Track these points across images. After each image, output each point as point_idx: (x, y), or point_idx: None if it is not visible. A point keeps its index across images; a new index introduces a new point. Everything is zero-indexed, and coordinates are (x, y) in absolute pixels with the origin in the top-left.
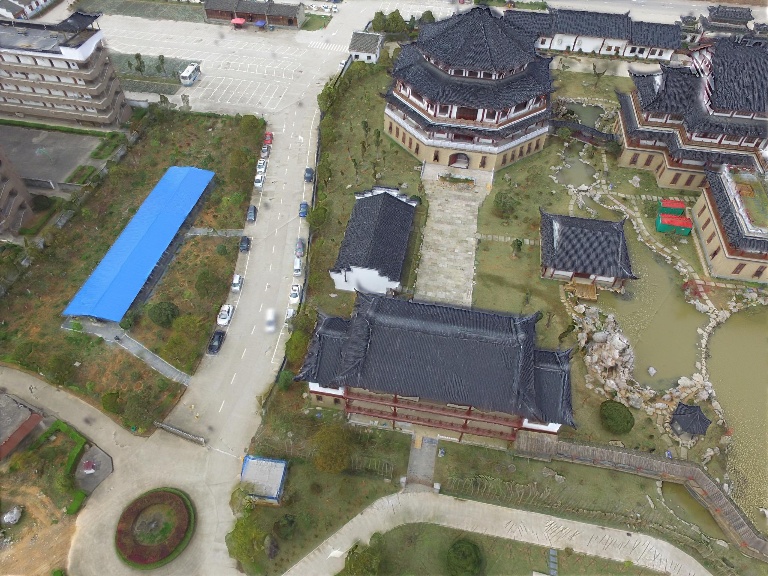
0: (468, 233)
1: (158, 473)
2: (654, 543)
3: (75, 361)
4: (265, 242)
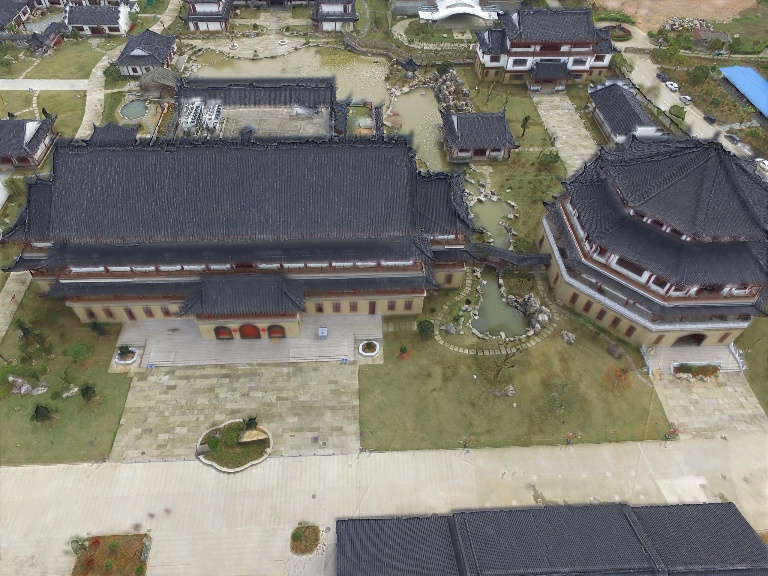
0: (563, 150)
1: (632, 44)
2: None
3: (717, 64)
4: (699, 125)
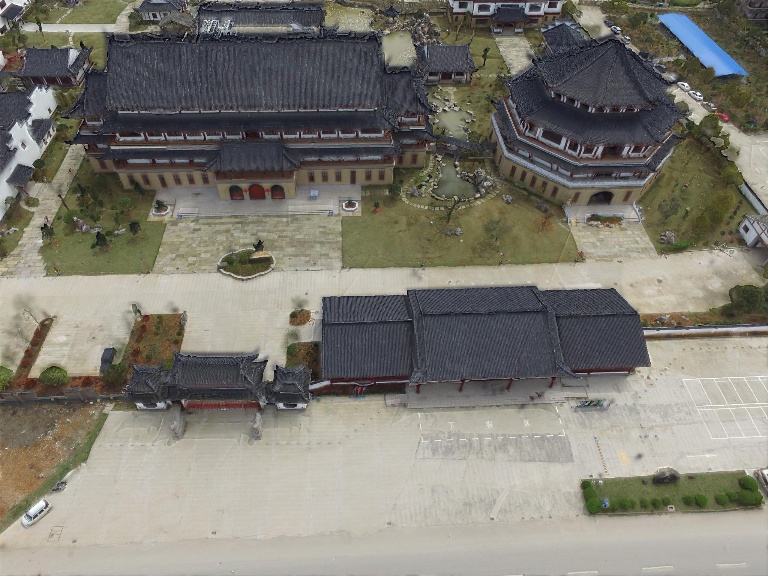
0: None
1: None
2: (406, 1)
3: (658, 13)
4: None
